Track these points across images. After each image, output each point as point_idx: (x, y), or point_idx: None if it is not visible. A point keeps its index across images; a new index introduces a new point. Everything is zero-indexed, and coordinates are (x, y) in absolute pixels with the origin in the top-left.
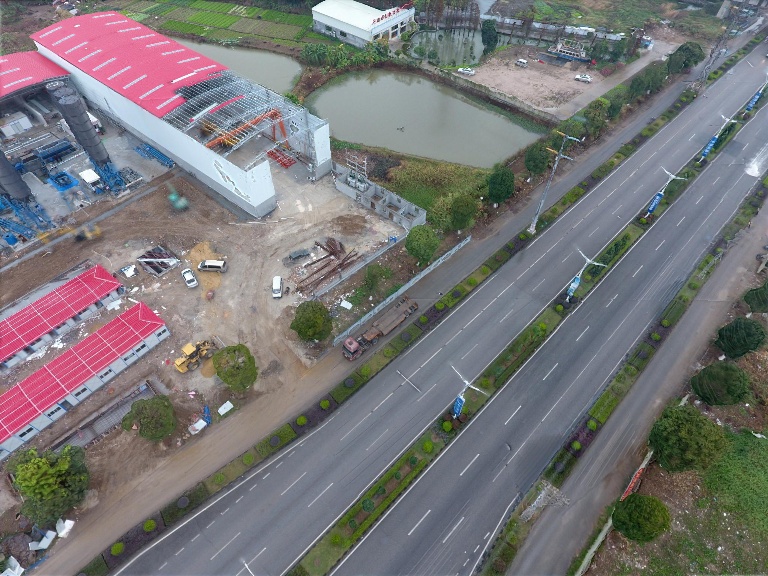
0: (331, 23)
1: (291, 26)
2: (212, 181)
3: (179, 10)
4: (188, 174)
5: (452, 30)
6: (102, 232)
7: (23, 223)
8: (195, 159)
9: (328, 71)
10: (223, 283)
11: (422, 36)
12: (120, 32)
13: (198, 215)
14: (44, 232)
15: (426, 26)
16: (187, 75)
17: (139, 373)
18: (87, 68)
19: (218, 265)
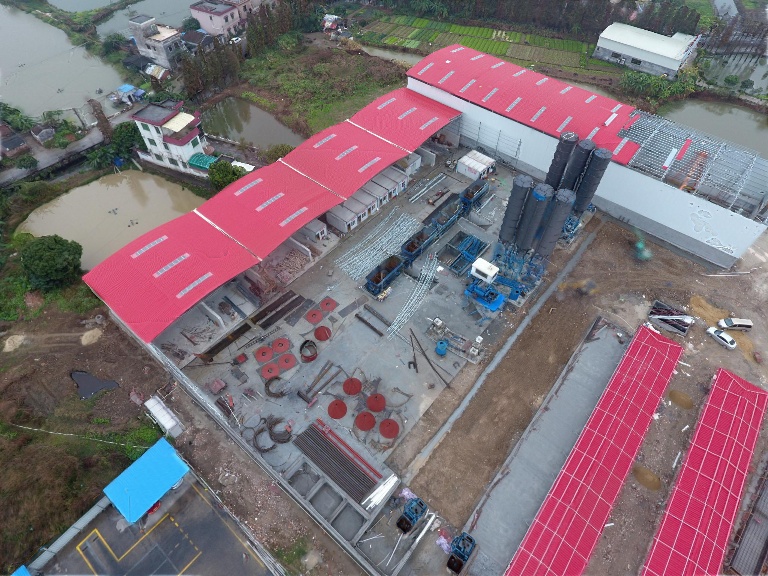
0: (623, 50)
1: (566, 52)
2: (664, 228)
3: (443, 36)
4: (615, 219)
5: (732, 56)
6: (585, 285)
7: (504, 275)
8: (651, 206)
9: (648, 102)
10: (755, 343)
11: (698, 62)
12: (494, 68)
13: (664, 265)
14: (534, 285)
15: (707, 52)
16: (611, 116)
17: (760, 448)
18: (499, 109)
19: (749, 324)
